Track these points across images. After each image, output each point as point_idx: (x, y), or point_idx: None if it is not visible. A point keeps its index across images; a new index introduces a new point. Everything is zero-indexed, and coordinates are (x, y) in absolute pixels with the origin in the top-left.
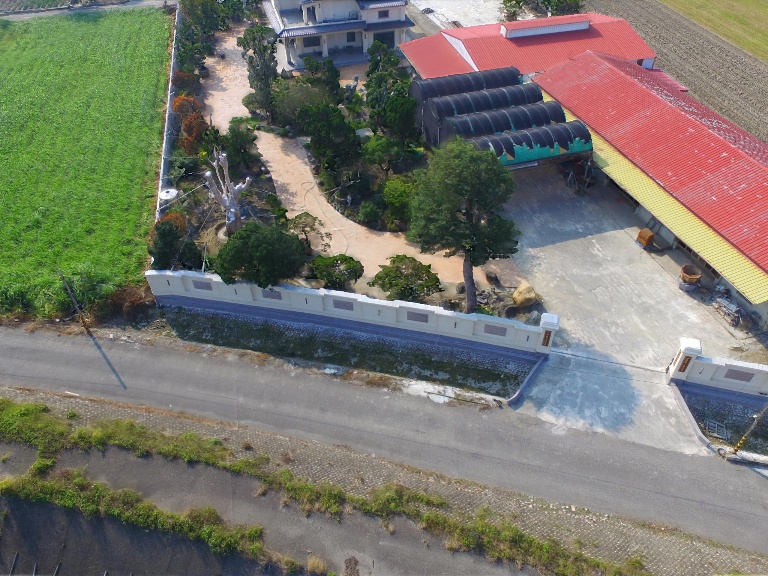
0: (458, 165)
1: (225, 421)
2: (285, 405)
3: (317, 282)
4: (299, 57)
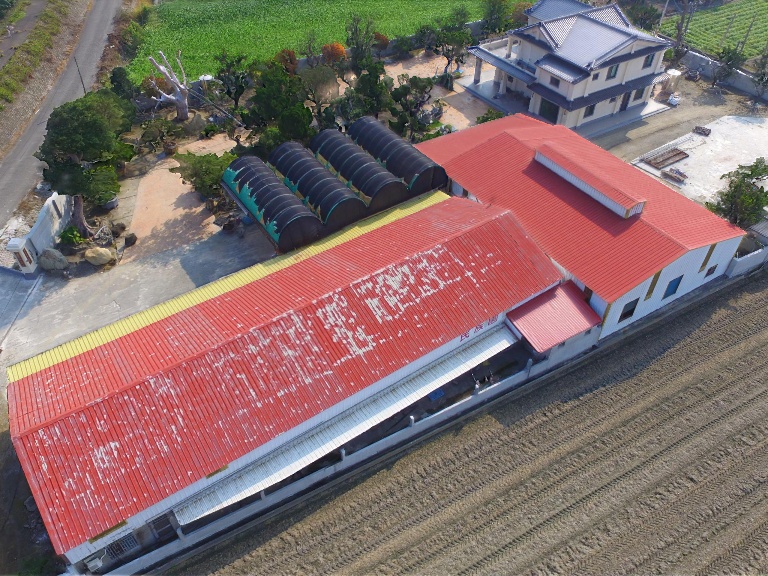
0: None
1: (3, 159)
2: (11, 175)
3: (134, 164)
4: (494, 83)
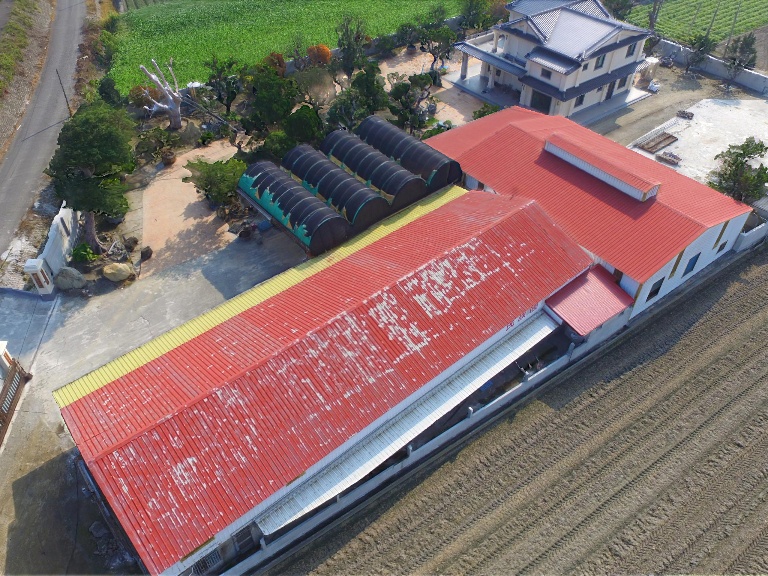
0: (76, 117)
1: None
2: (4, 195)
3: (133, 176)
4: (481, 78)
